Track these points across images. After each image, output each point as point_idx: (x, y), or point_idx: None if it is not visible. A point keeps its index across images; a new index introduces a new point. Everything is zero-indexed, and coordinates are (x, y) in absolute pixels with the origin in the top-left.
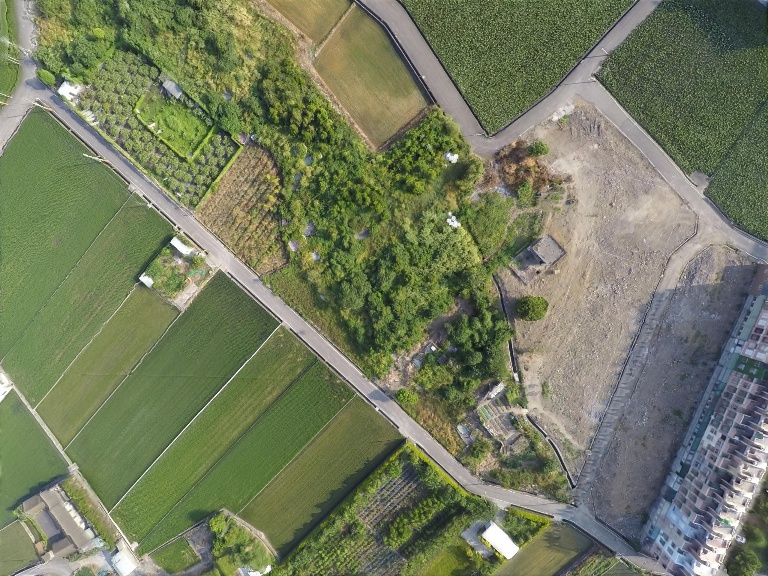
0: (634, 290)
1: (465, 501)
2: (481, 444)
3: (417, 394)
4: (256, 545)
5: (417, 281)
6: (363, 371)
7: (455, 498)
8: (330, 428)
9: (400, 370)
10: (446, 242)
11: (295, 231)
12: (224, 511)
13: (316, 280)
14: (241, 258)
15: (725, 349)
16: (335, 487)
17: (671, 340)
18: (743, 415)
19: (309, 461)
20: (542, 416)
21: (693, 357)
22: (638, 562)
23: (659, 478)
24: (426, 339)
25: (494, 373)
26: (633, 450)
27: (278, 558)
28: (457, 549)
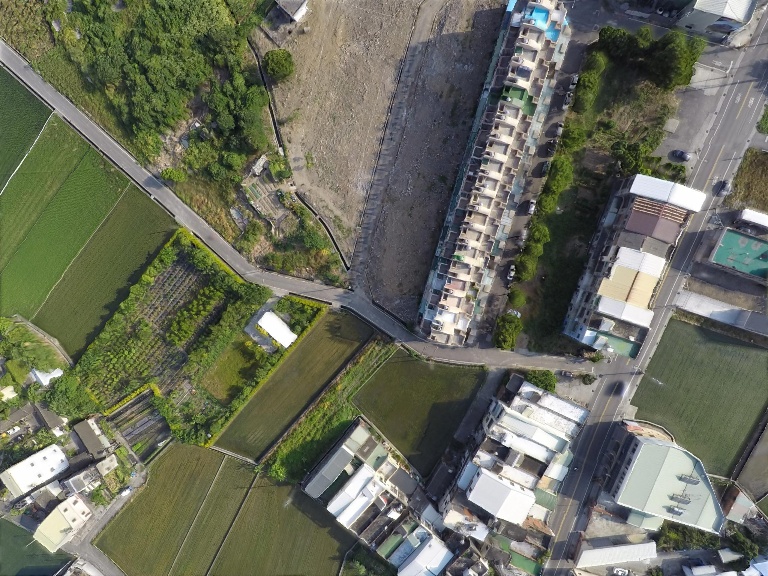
0: (386, 45)
1: (237, 285)
2: (252, 226)
3: (189, 178)
4: (43, 345)
5: (170, 47)
6: (136, 158)
7: (225, 280)
8: (110, 221)
9: (170, 153)
10: (194, 2)
11: (54, 7)
12: (18, 317)
13: (79, 59)
14: (11, 45)
15: (479, 101)
16: (120, 285)
17: (428, 98)
18: (475, 147)
19: (93, 258)
20: (310, 193)
21: (454, 118)
22: (418, 348)
23: (429, 252)
24: (190, 116)
25: (246, 137)
26: (400, 222)
27: (73, 365)
28: (242, 345)
